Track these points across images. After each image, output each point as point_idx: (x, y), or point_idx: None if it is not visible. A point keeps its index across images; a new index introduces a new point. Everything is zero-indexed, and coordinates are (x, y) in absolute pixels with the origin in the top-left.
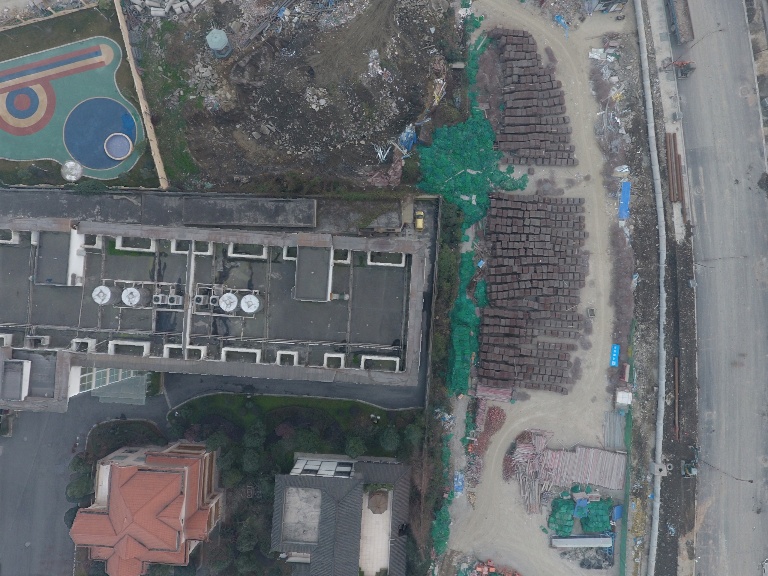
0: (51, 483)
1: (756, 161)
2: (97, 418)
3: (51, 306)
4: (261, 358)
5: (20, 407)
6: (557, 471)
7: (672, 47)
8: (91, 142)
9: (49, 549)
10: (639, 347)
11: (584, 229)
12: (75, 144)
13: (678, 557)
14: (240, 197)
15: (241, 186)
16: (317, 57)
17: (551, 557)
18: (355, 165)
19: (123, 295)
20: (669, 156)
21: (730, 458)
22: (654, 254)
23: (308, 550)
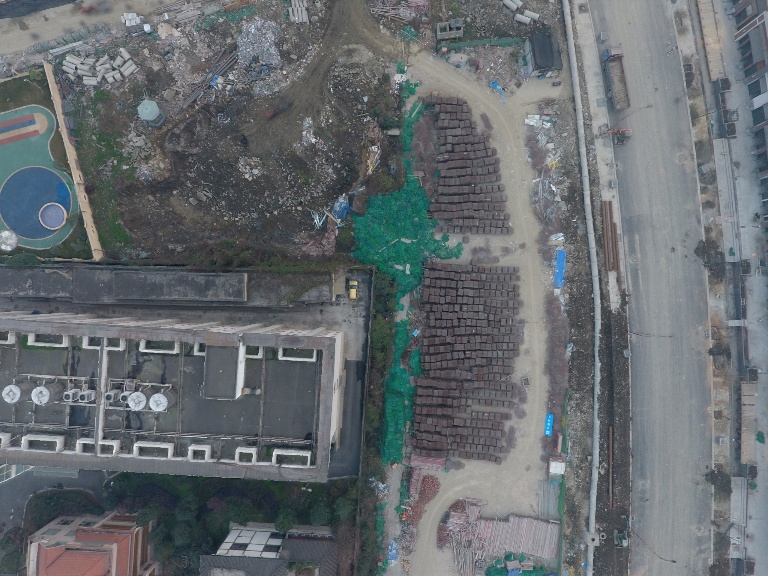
0: None
1: (693, 229)
2: (35, 487)
3: None
4: (174, 452)
5: None
6: (490, 541)
7: (609, 113)
8: (26, 212)
9: None
10: (574, 416)
11: (519, 298)
12: (10, 214)
13: None
14: (171, 271)
15: (176, 255)
16: (250, 125)
17: None
18: (291, 232)
19: (33, 394)
20: (604, 224)
21: (663, 527)
22: (589, 323)
23: None
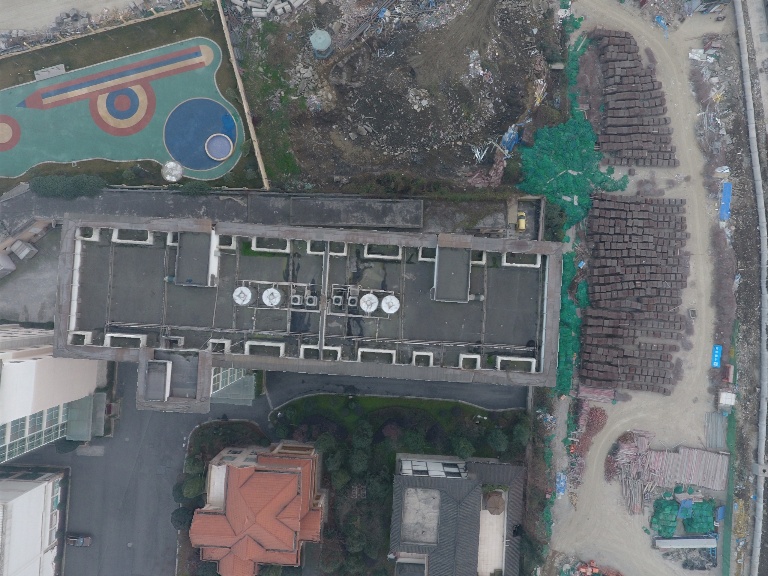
0: (153, 483)
1: None
2: (199, 419)
3: (185, 307)
4: (396, 359)
5: (163, 408)
6: (660, 472)
7: None
8: (191, 143)
9: (151, 549)
10: (740, 348)
11: (685, 230)
12: (175, 145)
13: None
14: (346, 198)
15: (341, 187)
16: (418, 58)
17: (653, 558)
18: (453, 166)
19: (264, 296)
20: None
21: None
22: (755, 255)
23: (427, 551)
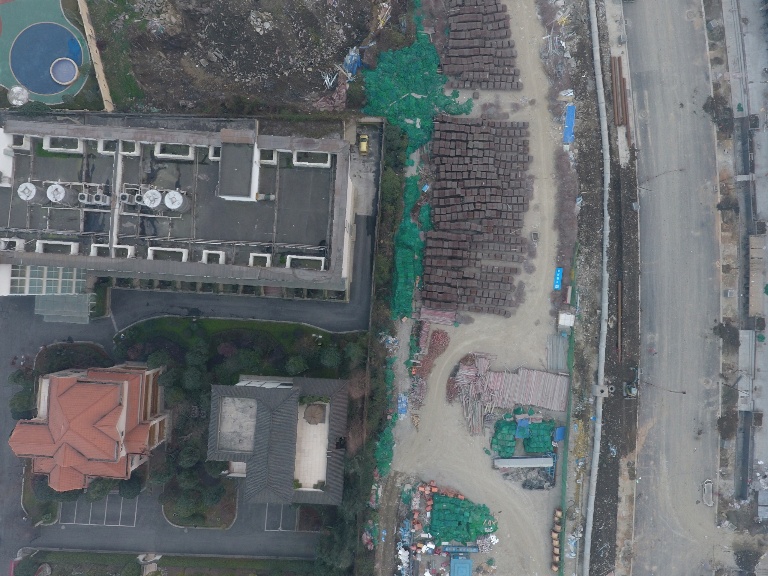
0: None
1: (701, 85)
2: (44, 341)
3: None
4: (188, 258)
5: None
6: (499, 392)
7: None
8: (37, 67)
9: None
10: (583, 271)
11: (528, 153)
12: (21, 69)
13: (619, 478)
14: (182, 118)
15: None
16: None
17: (494, 478)
18: (302, 92)
19: (48, 191)
20: (614, 79)
21: (672, 380)
22: (598, 178)
23: (244, 459)
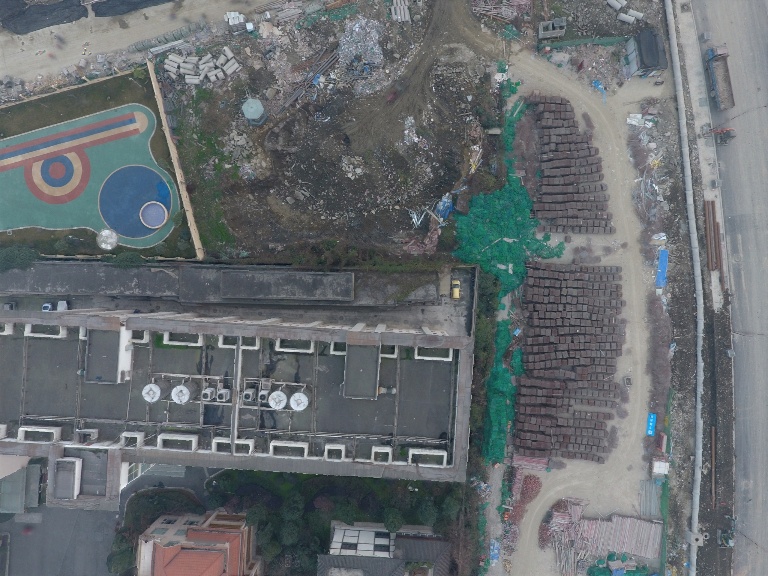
0: (91, 550)
1: None
2: (135, 486)
3: (99, 399)
4: (309, 452)
5: (72, 505)
6: (593, 540)
7: (711, 113)
8: (126, 210)
9: None
10: (676, 416)
11: (621, 298)
12: (110, 212)
13: None
14: (277, 270)
15: (276, 254)
16: (352, 124)
17: None
18: (390, 231)
19: (173, 393)
20: (708, 224)
21: (766, 527)
22: (691, 323)
23: None
